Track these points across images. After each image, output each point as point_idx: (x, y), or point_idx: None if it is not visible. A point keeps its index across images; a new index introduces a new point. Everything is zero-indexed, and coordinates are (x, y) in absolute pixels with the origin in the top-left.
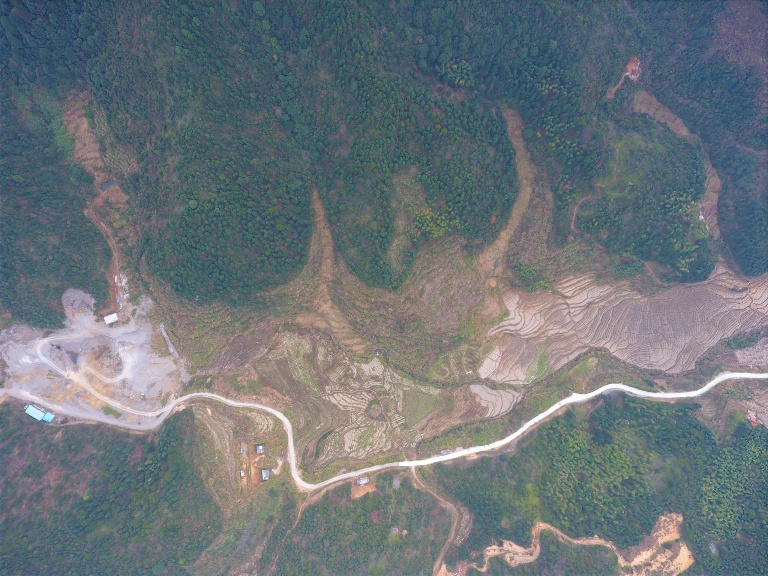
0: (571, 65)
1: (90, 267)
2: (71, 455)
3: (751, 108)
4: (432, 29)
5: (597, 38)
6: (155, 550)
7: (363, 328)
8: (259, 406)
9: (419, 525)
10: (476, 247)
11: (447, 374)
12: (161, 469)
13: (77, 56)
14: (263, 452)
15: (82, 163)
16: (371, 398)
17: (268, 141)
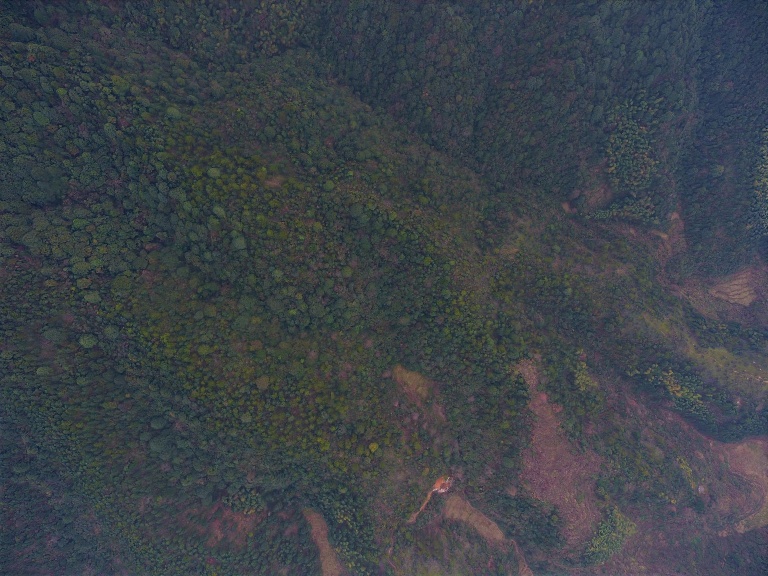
0: (364, 503)
1: None
2: None
3: (556, 541)
4: None
5: (389, 485)
6: None
7: None
8: None
9: None
10: None
11: None
12: None
13: None
14: None
15: None
16: None
17: (42, 567)
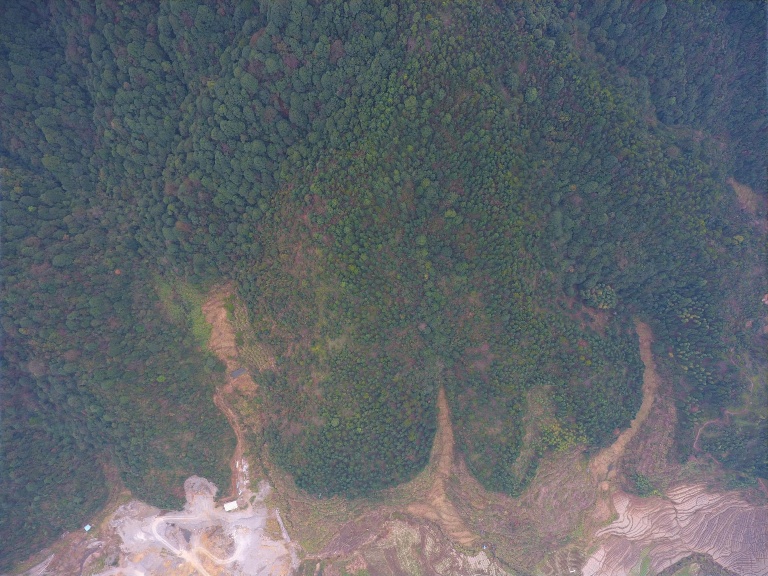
0: (716, 300)
1: (218, 459)
2: None
3: None
4: (585, 261)
5: (747, 279)
6: None
7: (475, 525)
8: None
9: None
10: (593, 452)
11: (551, 572)
12: None
13: (227, 257)
14: None
15: (216, 351)
16: None
17: (408, 353)
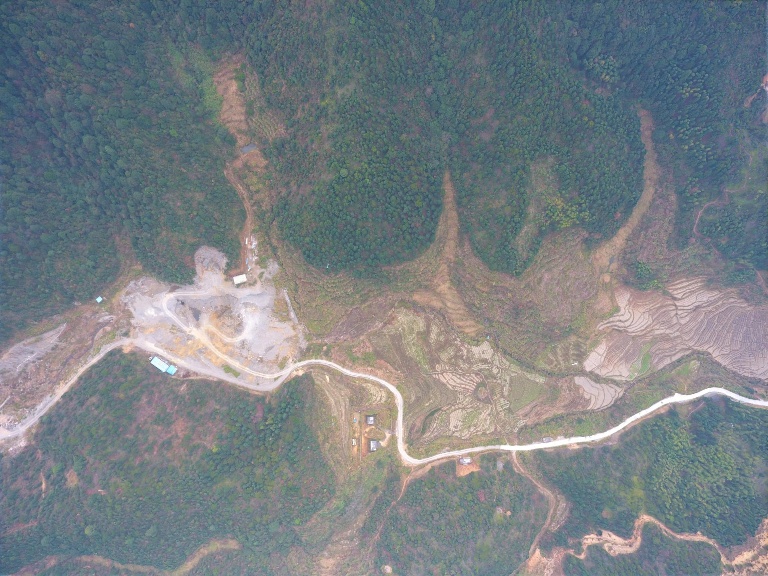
0: (716, 71)
1: (228, 226)
2: (197, 408)
3: None
4: (588, 23)
5: (745, 46)
6: (273, 508)
7: (479, 311)
8: (373, 378)
9: (522, 508)
10: (595, 241)
11: (554, 364)
12: (282, 430)
13: (239, 19)
14: (373, 423)
15: (227, 124)
16: (479, 380)
17: (415, 118)
